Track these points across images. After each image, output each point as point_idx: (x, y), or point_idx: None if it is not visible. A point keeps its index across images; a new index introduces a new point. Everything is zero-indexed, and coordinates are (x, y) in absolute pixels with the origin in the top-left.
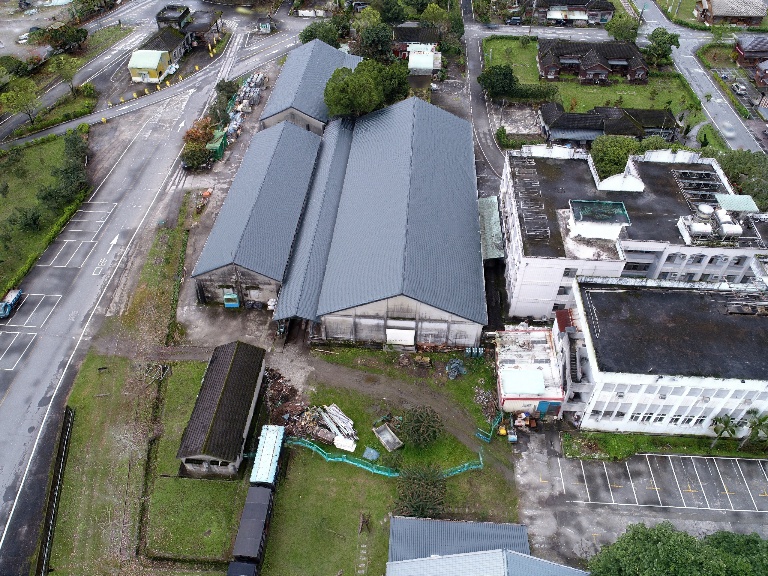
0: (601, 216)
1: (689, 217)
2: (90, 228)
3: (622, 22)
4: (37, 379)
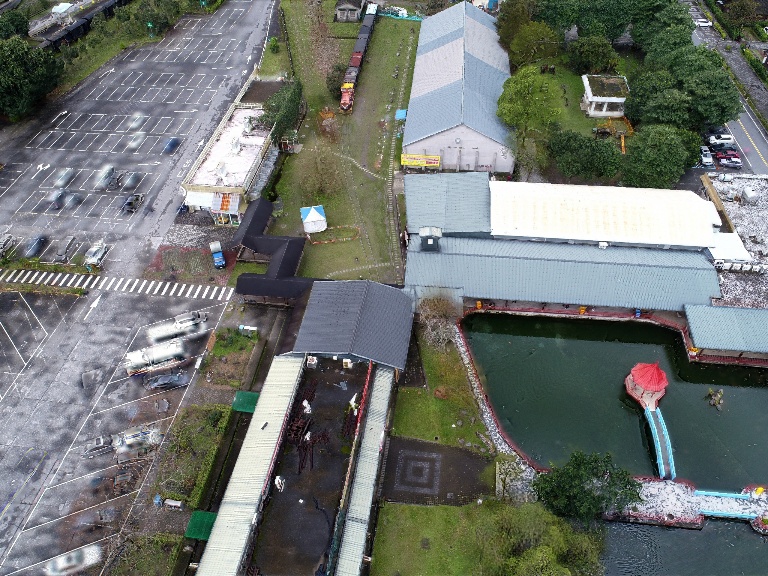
0: None
1: None
2: None
3: None
4: (263, 3)
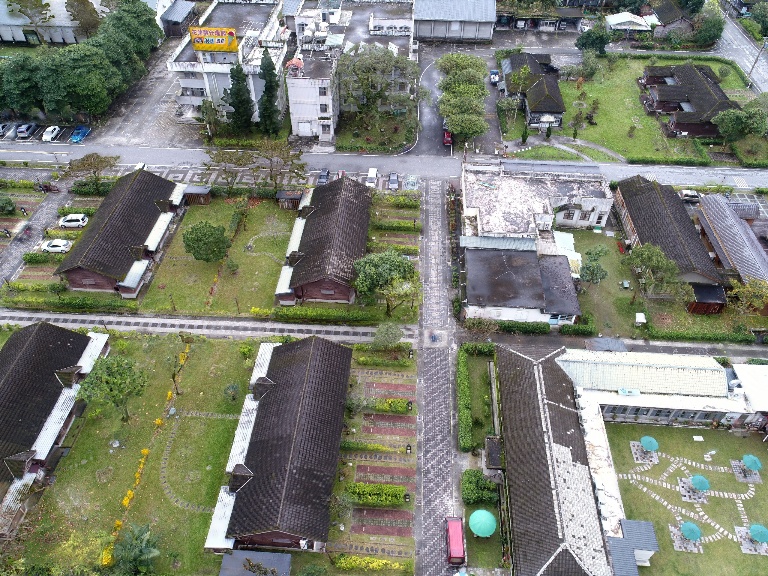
0: (326, 4)
1: (330, 33)
2: None
3: (766, 92)
4: None
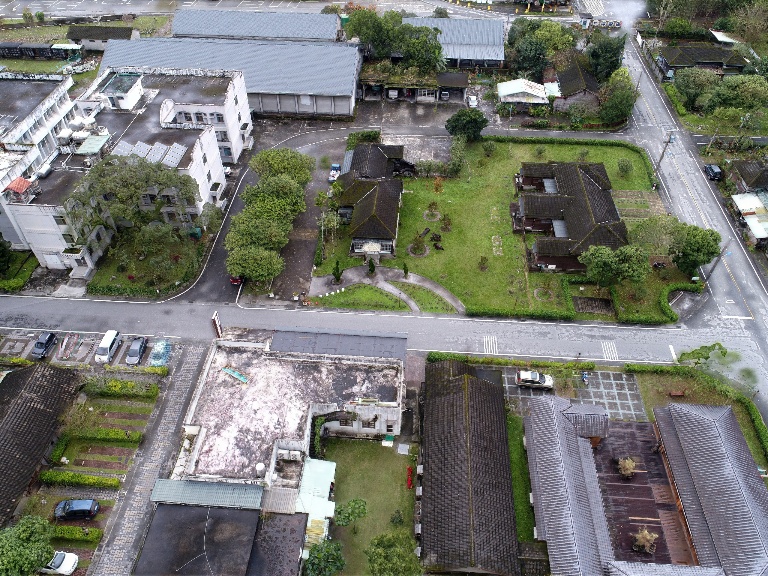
0: (117, 84)
1: (102, 129)
2: (273, 4)
3: (655, 217)
4: None
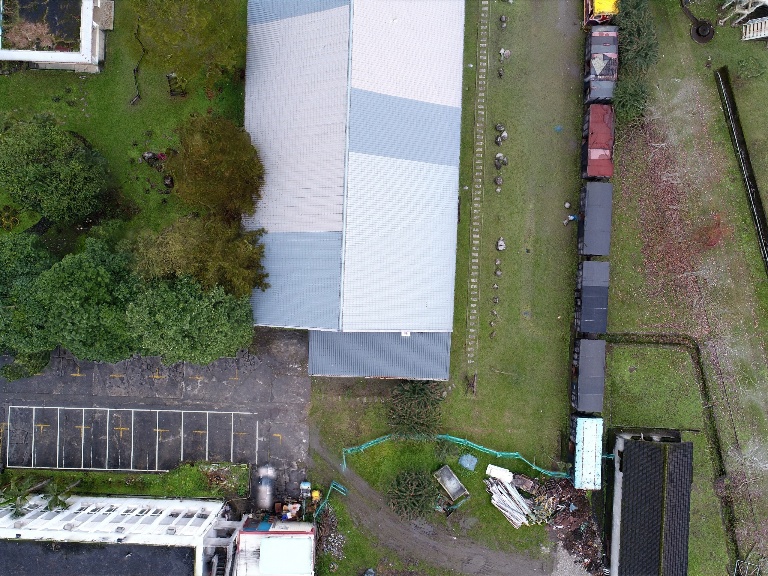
0: None
1: None
2: None
3: None
4: None
